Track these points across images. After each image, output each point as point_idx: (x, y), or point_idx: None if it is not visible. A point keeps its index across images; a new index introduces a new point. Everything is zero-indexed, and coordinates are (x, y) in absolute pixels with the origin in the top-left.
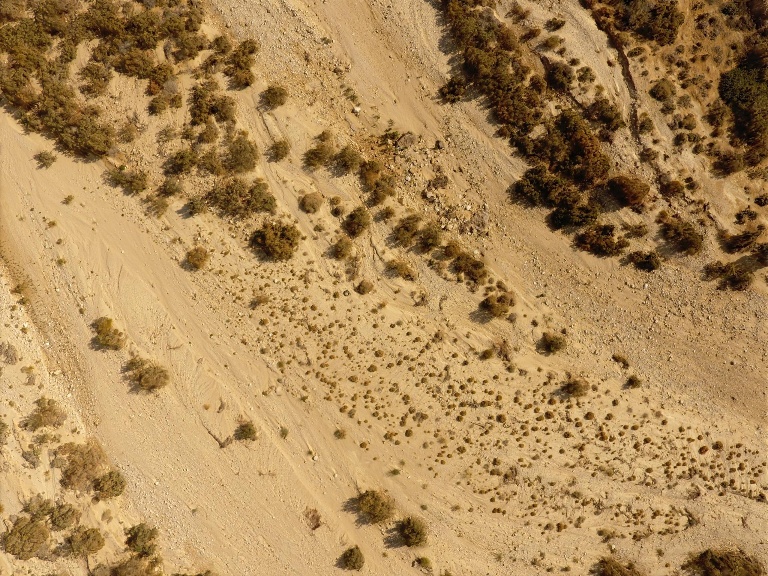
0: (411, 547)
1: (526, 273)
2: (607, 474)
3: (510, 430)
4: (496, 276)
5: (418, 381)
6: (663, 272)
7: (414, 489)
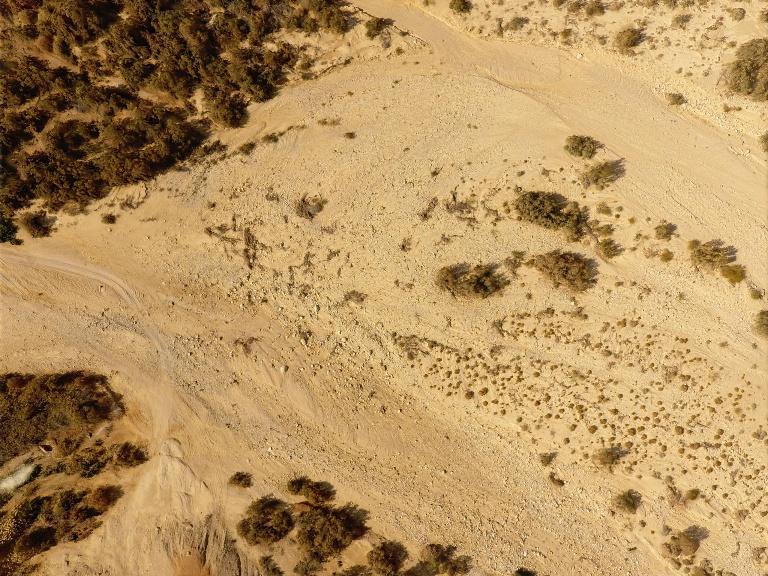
0: (767, 309)
1: (646, 574)
2: (577, 373)
3: (671, 419)
4: (679, 573)
5: (763, 472)
6: (508, 568)
7: (764, 364)
